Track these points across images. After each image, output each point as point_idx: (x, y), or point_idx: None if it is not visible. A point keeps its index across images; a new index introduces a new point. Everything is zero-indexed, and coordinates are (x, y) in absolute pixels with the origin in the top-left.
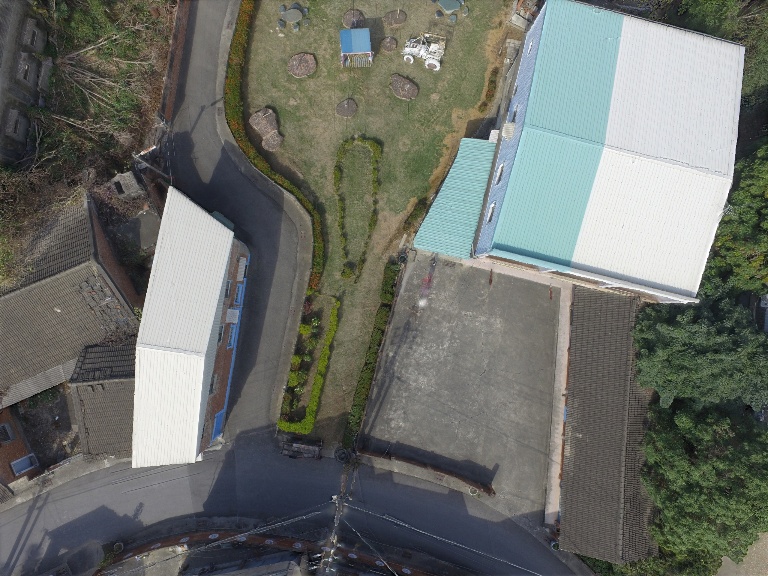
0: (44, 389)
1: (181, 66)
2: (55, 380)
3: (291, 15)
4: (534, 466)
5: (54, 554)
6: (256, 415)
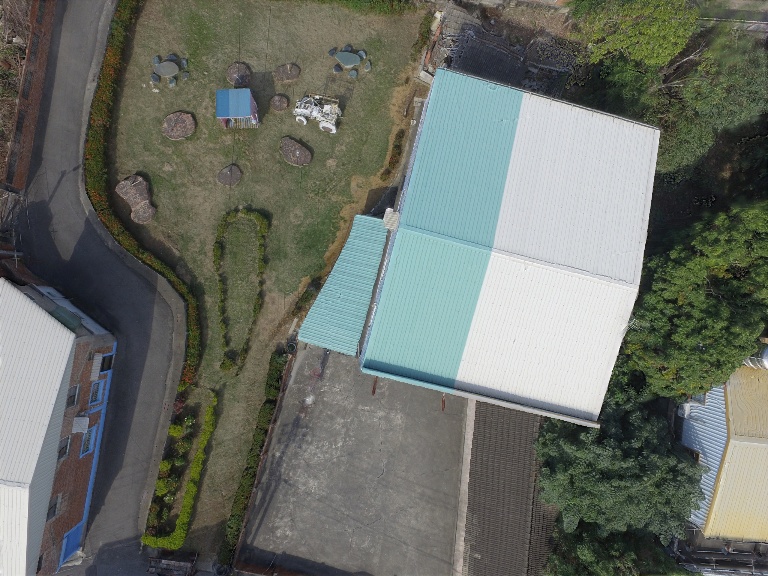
0: None
1: (37, 125)
2: None
3: (165, 68)
4: None
5: None
6: (122, 525)
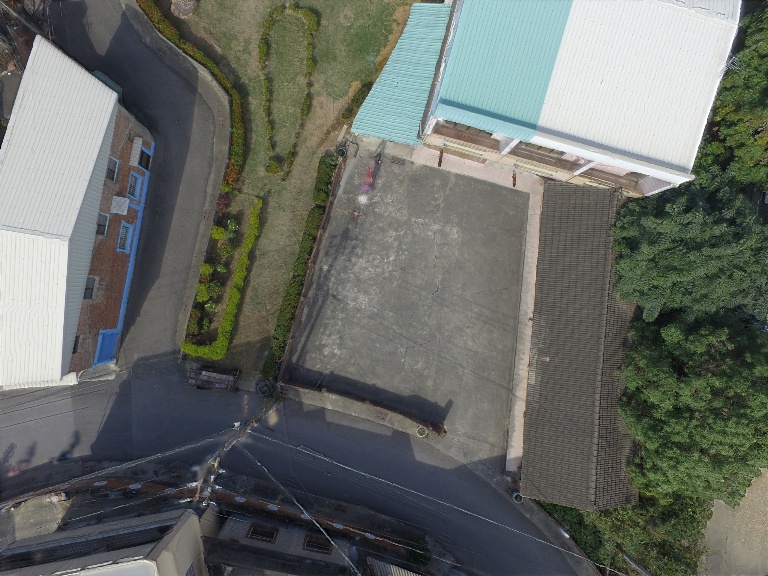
0: None
1: None
2: None
3: None
4: (494, 403)
5: None
6: (159, 338)
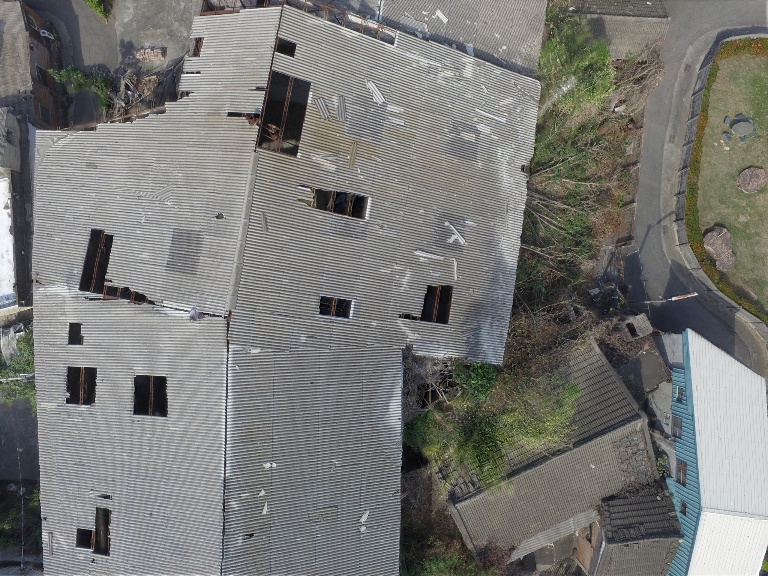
0: (553, 541)
1: None
2: (564, 532)
3: (742, 128)
4: None
5: None
6: None
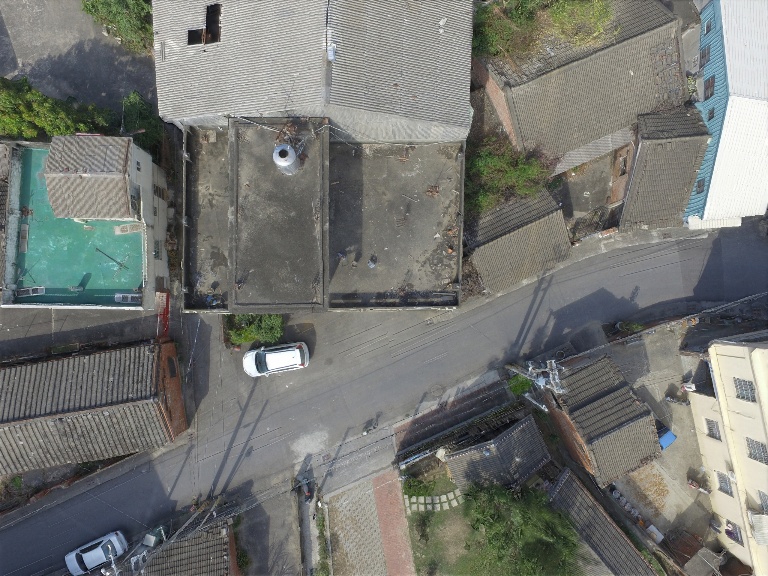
0: None
1: None
2: (603, 149)
3: None
4: None
5: (559, 333)
6: None
